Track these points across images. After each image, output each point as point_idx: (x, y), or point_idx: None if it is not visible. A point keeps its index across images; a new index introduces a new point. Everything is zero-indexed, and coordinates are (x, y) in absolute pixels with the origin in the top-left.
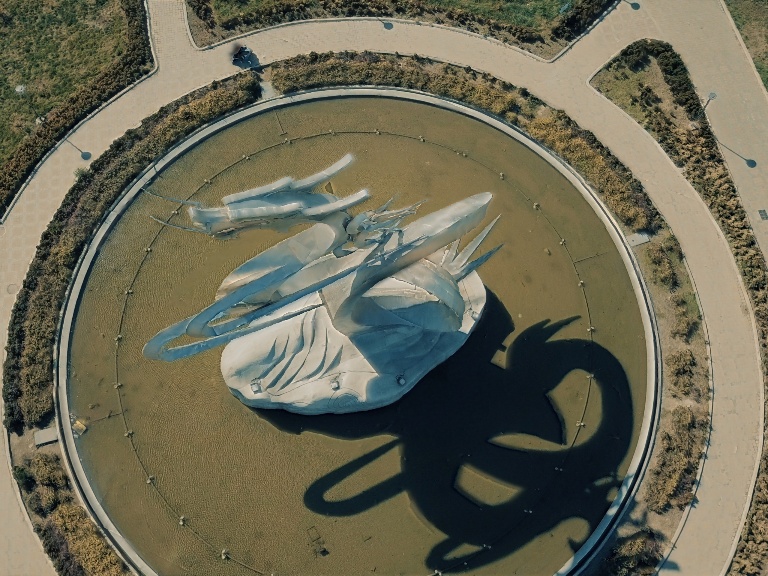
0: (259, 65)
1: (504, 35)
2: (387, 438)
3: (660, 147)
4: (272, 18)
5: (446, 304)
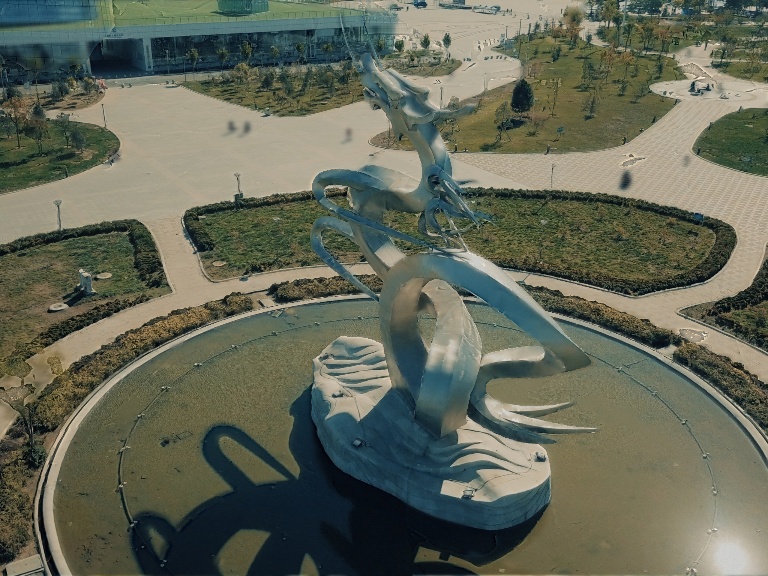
0: (693, 341)
1: None
2: (296, 471)
3: None
4: (757, 339)
5: (427, 361)
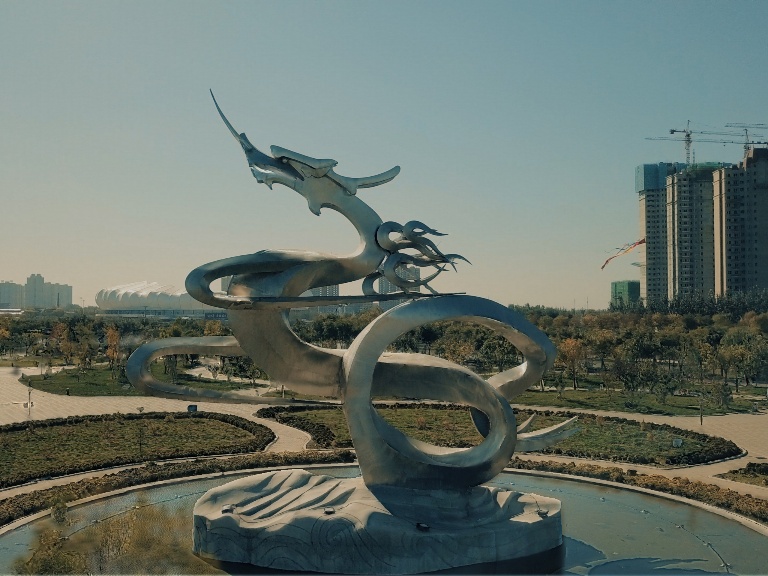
0: None
1: None
2: None
3: None
4: None
5: (486, 388)
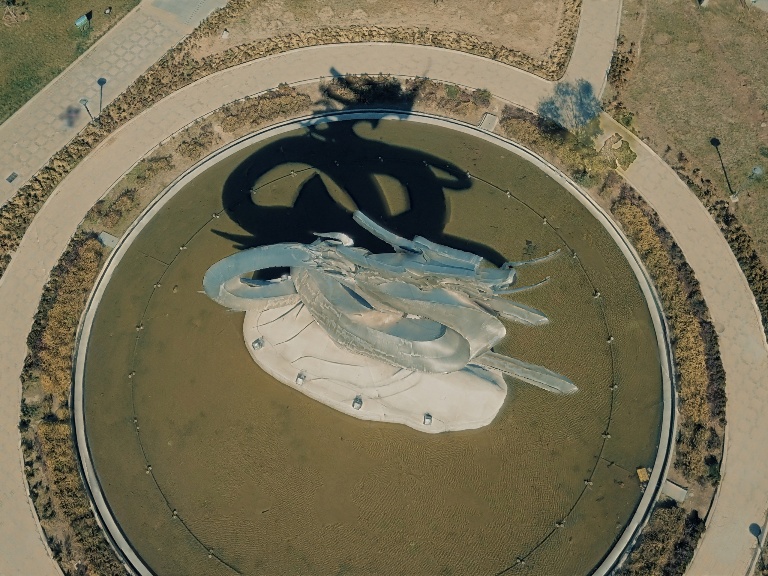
0: None
1: None
2: None
3: None
4: None
5: None
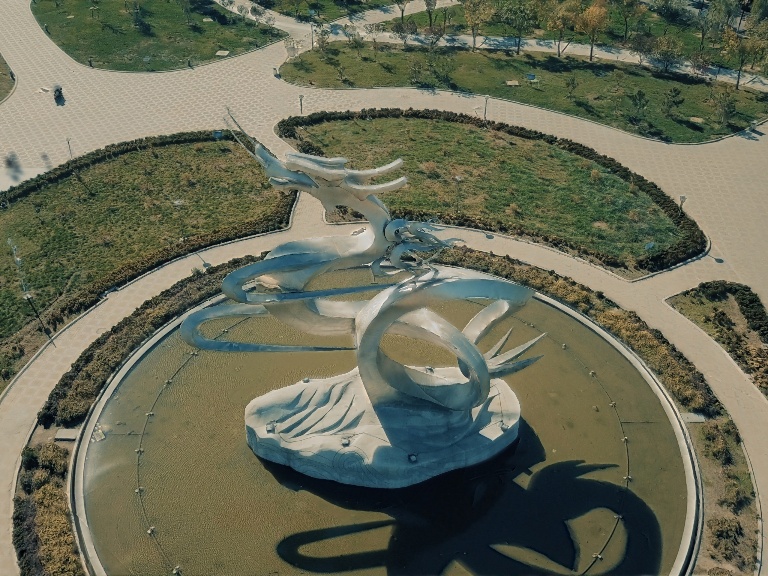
0: None
1: (591, 258)
2: (383, 516)
3: (728, 355)
4: (394, 216)
5: (469, 363)
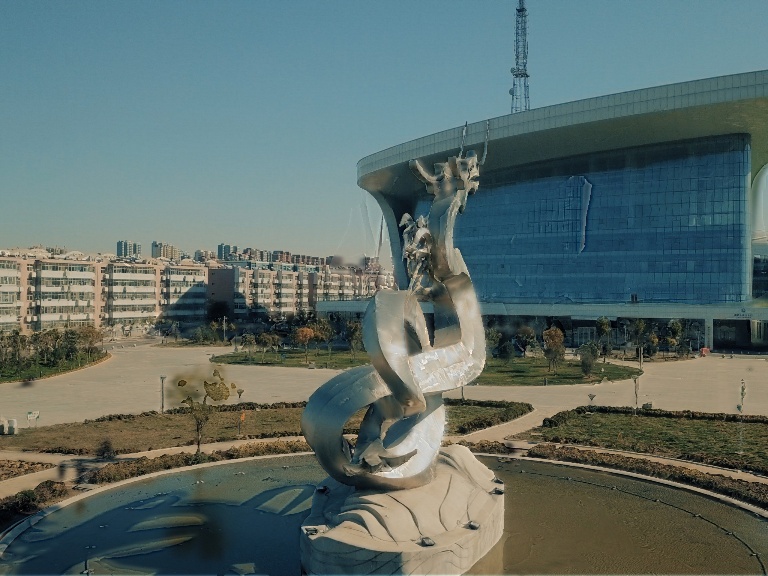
0: None
1: None
2: None
3: None
4: None
5: None
